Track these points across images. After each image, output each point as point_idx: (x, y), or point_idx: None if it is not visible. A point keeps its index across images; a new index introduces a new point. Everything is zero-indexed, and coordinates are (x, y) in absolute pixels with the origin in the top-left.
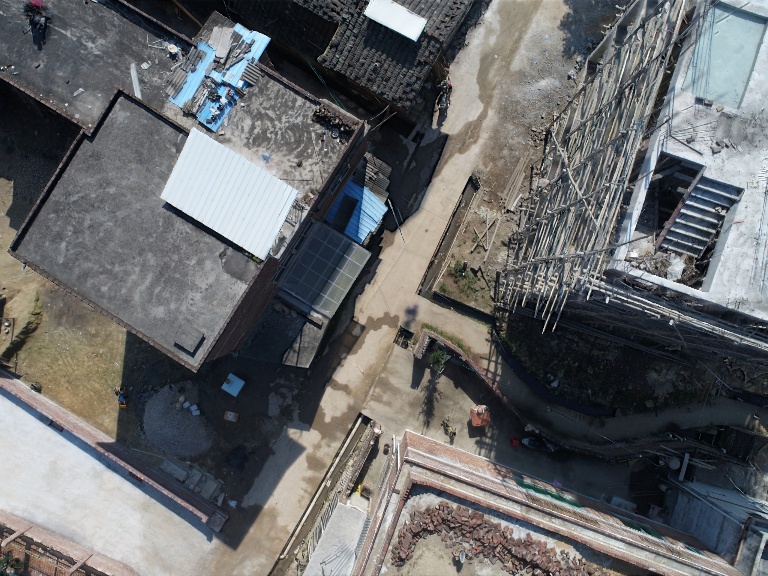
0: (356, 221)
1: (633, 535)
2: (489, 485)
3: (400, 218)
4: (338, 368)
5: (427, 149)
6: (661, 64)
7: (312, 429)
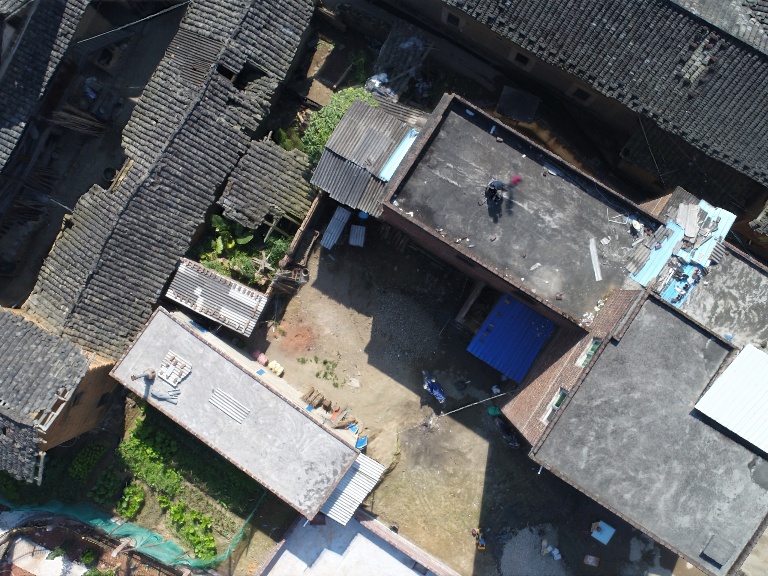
0: None
1: None
2: None
3: None
4: None
5: None
6: None
7: (673, 575)
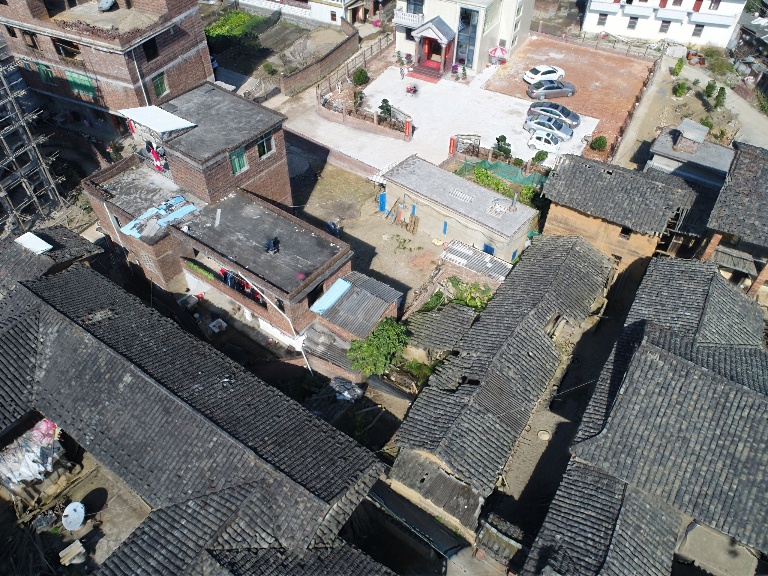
0: None
1: (47, 57)
2: (98, 65)
3: None
4: None
5: None
6: None
7: None
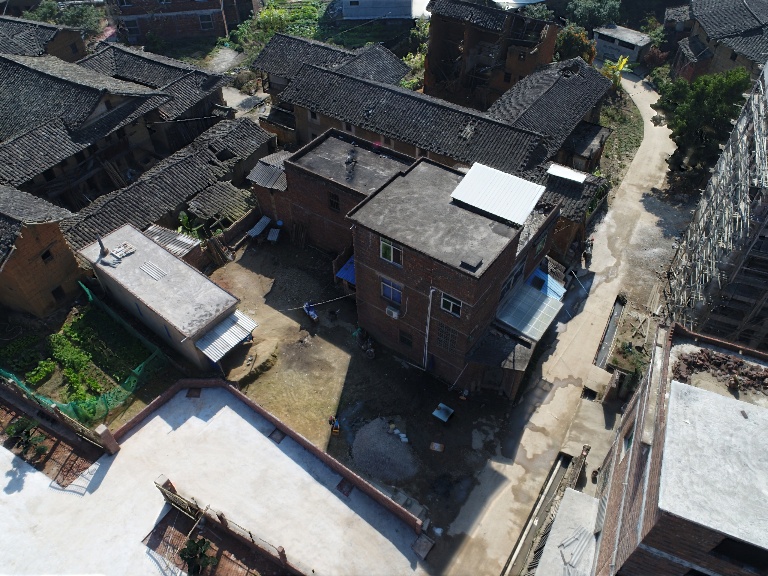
0: (545, 293)
1: None
2: None
3: (569, 316)
4: (534, 414)
5: (581, 279)
6: (759, 116)
7: (515, 464)
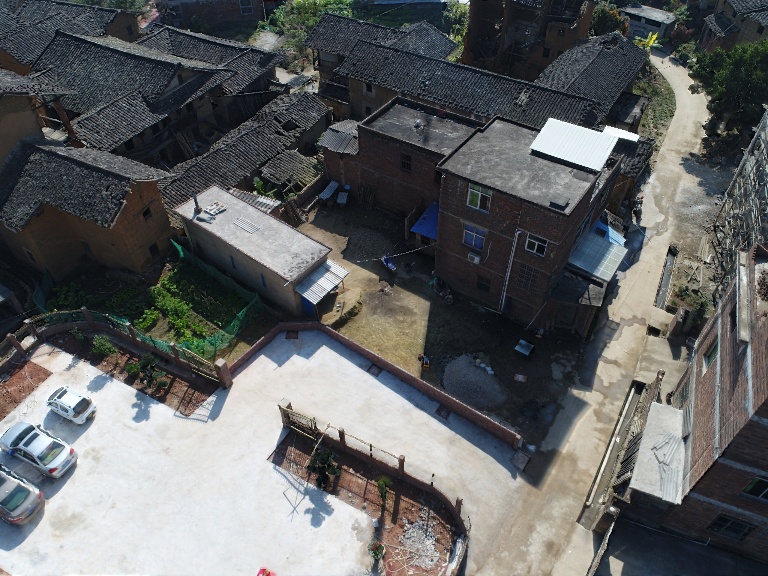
0: None
1: None
2: None
3: (627, 265)
4: (605, 349)
5: (634, 233)
6: None
7: (594, 391)
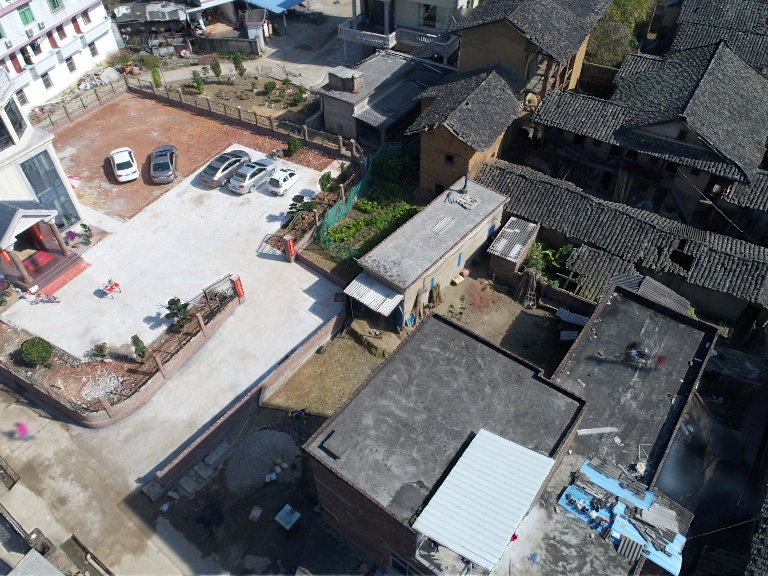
0: None
1: None
2: None
3: None
4: None
5: None
6: None
7: None
